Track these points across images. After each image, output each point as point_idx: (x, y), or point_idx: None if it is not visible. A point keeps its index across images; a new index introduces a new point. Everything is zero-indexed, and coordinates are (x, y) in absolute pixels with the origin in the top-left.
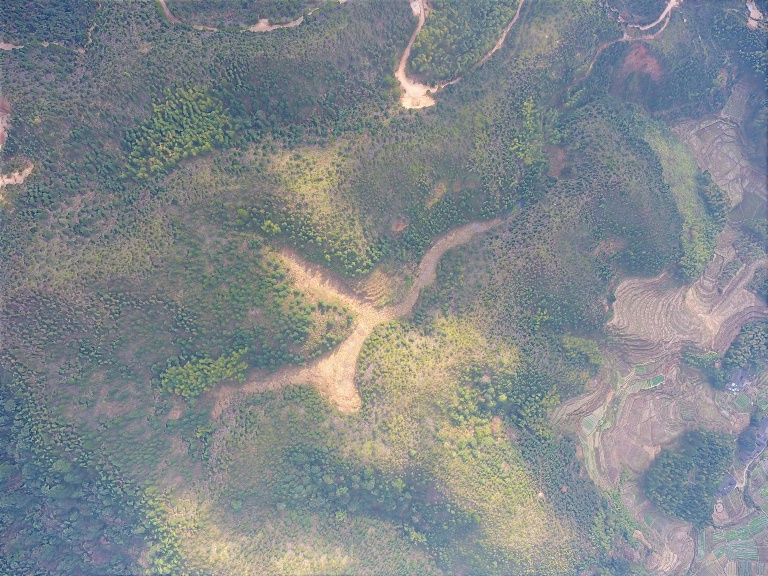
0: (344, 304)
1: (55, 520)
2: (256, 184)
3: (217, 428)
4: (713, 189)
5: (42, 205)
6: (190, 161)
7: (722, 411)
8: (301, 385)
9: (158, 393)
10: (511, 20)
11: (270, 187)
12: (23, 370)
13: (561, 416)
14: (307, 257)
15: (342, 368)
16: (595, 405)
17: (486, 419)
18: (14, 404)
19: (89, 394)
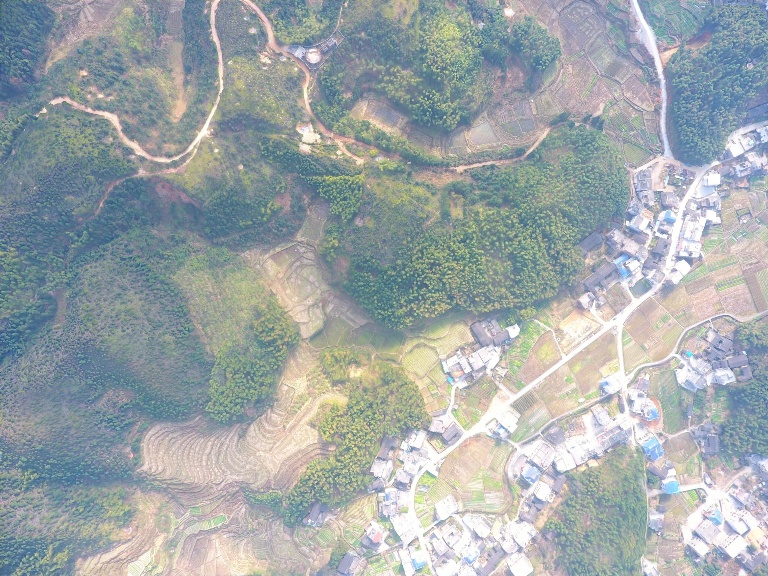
0: None
1: None
2: None
3: None
4: (260, 325)
5: None
6: None
7: (302, 547)
8: None
9: None
10: (6, 159)
11: None
12: None
13: (95, 565)
14: None
15: None
16: (138, 551)
17: None
18: None
19: None
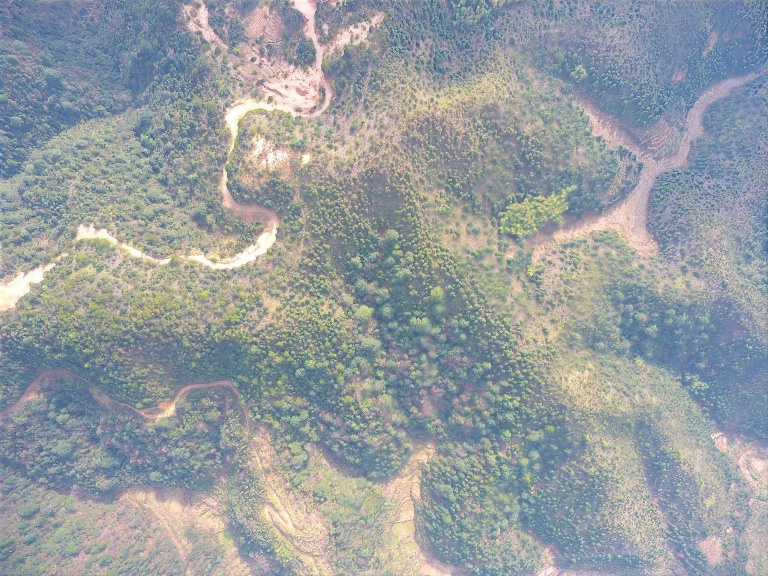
0: (632, 154)
1: (408, 361)
2: (572, 27)
3: (545, 268)
4: None
5: (401, 45)
6: (510, 8)
7: None
8: (606, 230)
9: (496, 233)
10: None
11: (584, 30)
12: (413, 194)
13: None
14: (604, 105)
15: (634, 216)
16: None
17: (765, 261)
18: (397, 232)
19: (453, 226)
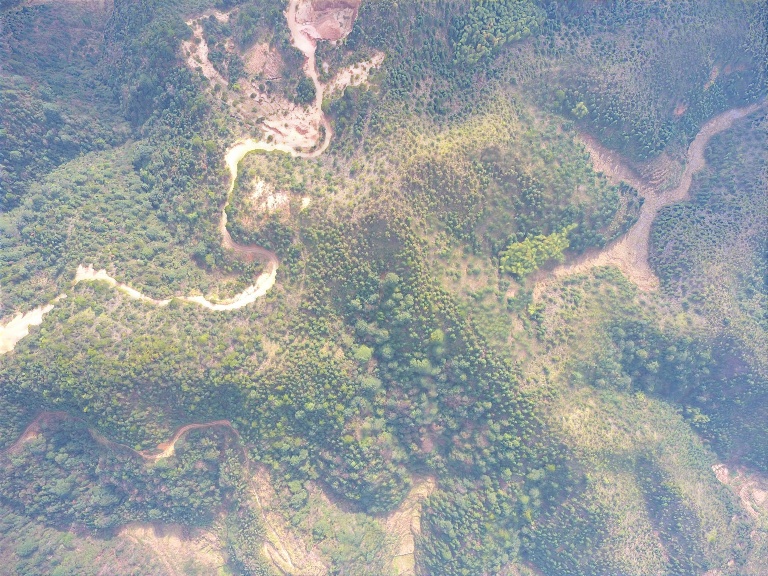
0: (633, 188)
1: (408, 401)
2: (573, 65)
3: (546, 306)
4: None
5: (402, 86)
6: (511, 46)
7: None
8: (607, 265)
9: (496, 272)
10: None
11: (585, 68)
12: (413, 238)
13: None
14: (605, 141)
15: (635, 251)
16: None
17: (767, 295)
18: (397, 276)
19: (453, 267)
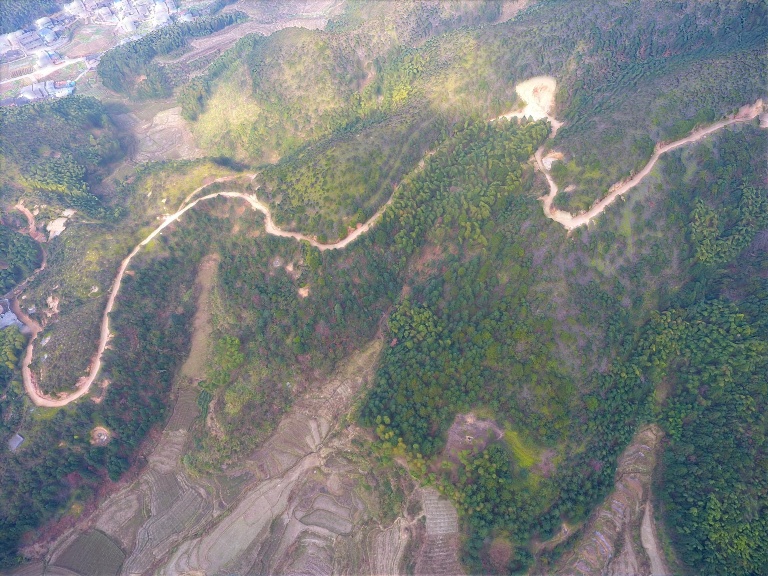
0: None
1: None
2: None
3: None
4: None
5: None
6: None
7: None
8: None
9: None
10: None
11: None
12: None
13: None
14: None
15: None
16: None
17: None
18: None
19: None
